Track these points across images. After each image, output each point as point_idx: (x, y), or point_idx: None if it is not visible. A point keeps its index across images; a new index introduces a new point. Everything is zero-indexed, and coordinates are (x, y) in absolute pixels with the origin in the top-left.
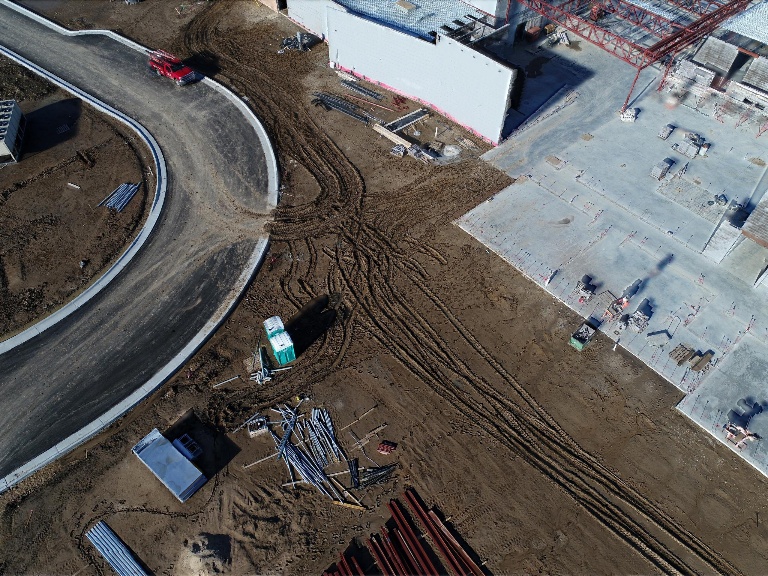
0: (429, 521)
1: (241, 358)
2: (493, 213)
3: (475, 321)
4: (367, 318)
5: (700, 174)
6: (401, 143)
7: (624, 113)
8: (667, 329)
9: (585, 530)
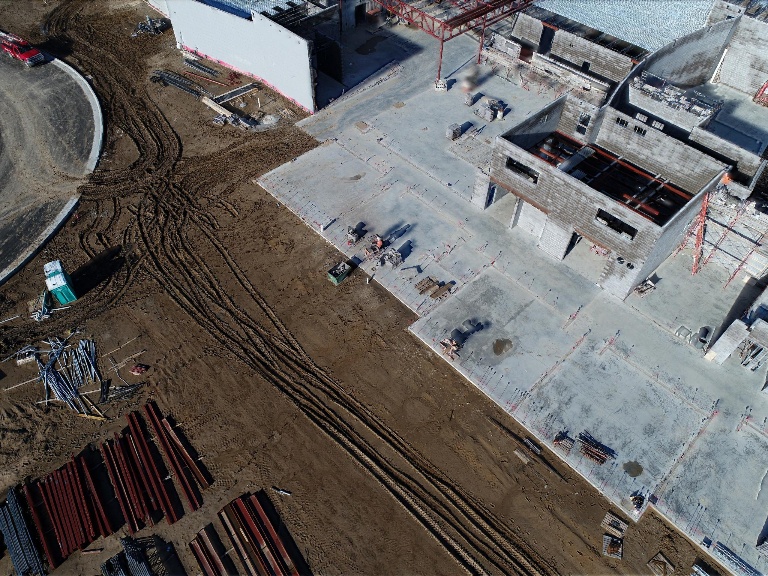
0: (160, 427)
1: (26, 300)
2: (292, 172)
3: (250, 263)
4: (152, 264)
5: (493, 135)
6: (224, 113)
7: (437, 83)
8: (420, 265)
9: (298, 429)
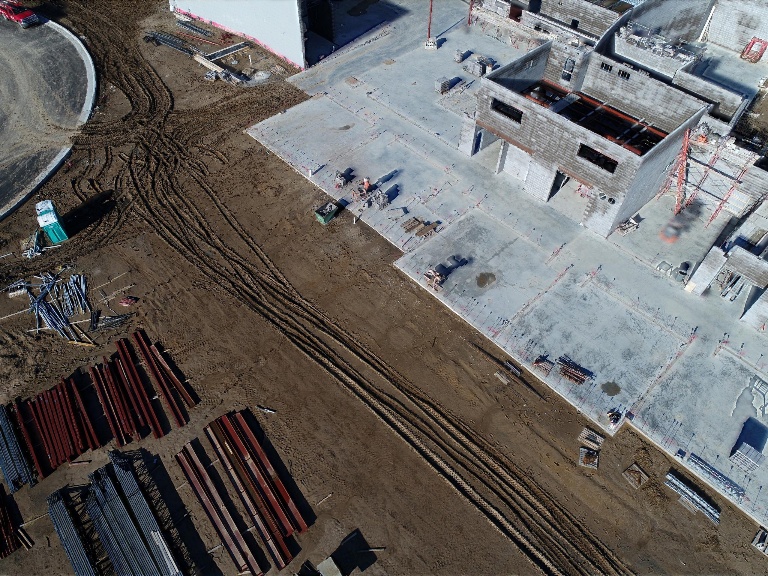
0: (148, 352)
1: (19, 239)
2: (282, 123)
3: (239, 206)
4: (143, 206)
5: None
6: (215, 69)
7: (427, 41)
8: (406, 206)
9: (284, 355)
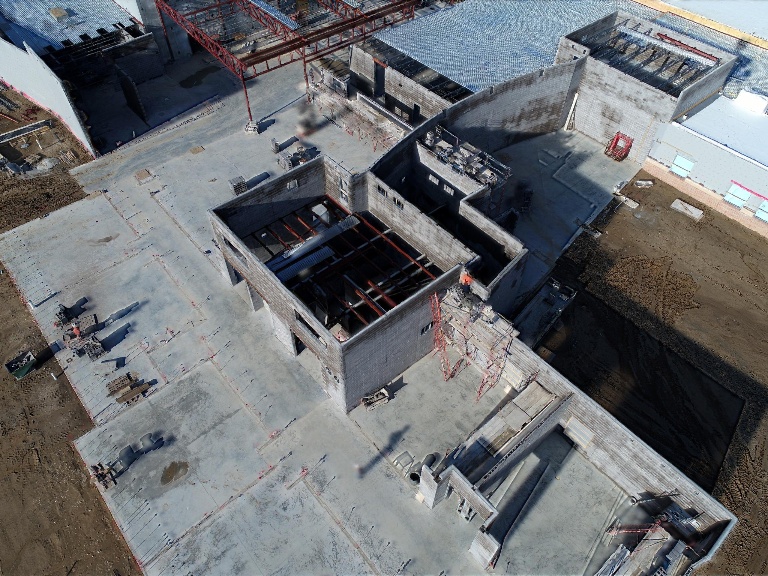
0: None
1: None
2: (36, 231)
3: None
4: None
5: None
6: None
7: (247, 125)
8: (126, 356)
9: None
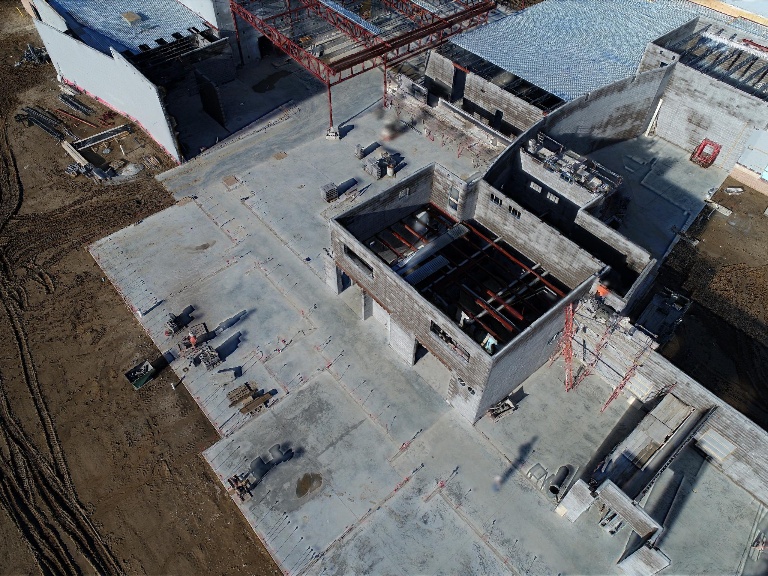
0: None
1: None
2: (132, 237)
3: (47, 356)
4: None
5: None
6: (79, 162)
7: (328, 131)
8: (242, 366)
9: None
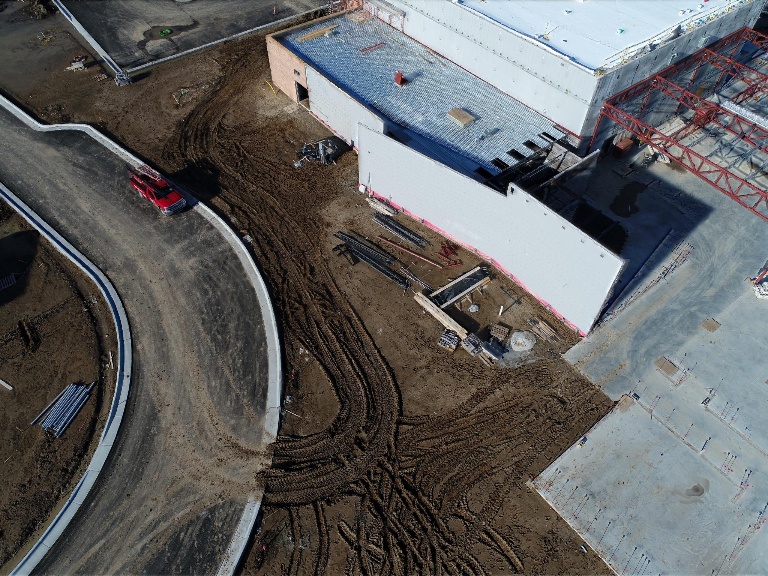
0: None
1: None
2: (588, 469)
3: None
4: None
5: None
6: (453, 329)
7: (761, 287)
8: None
9: None
